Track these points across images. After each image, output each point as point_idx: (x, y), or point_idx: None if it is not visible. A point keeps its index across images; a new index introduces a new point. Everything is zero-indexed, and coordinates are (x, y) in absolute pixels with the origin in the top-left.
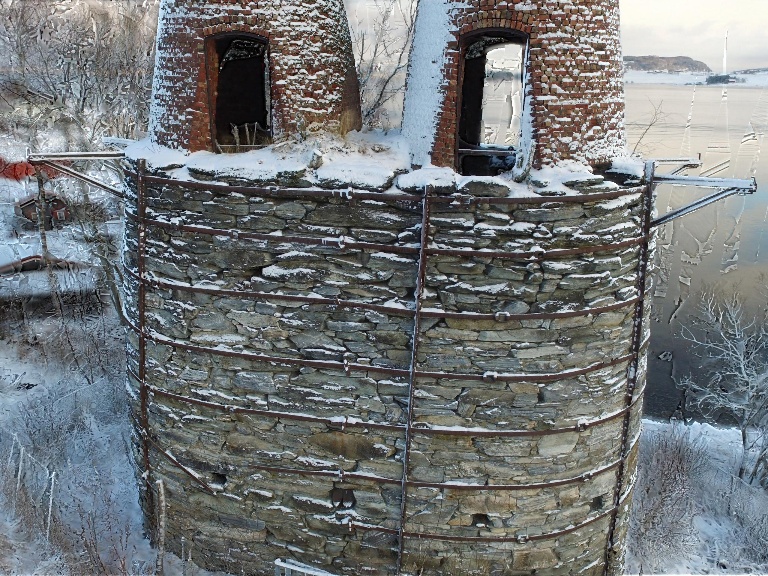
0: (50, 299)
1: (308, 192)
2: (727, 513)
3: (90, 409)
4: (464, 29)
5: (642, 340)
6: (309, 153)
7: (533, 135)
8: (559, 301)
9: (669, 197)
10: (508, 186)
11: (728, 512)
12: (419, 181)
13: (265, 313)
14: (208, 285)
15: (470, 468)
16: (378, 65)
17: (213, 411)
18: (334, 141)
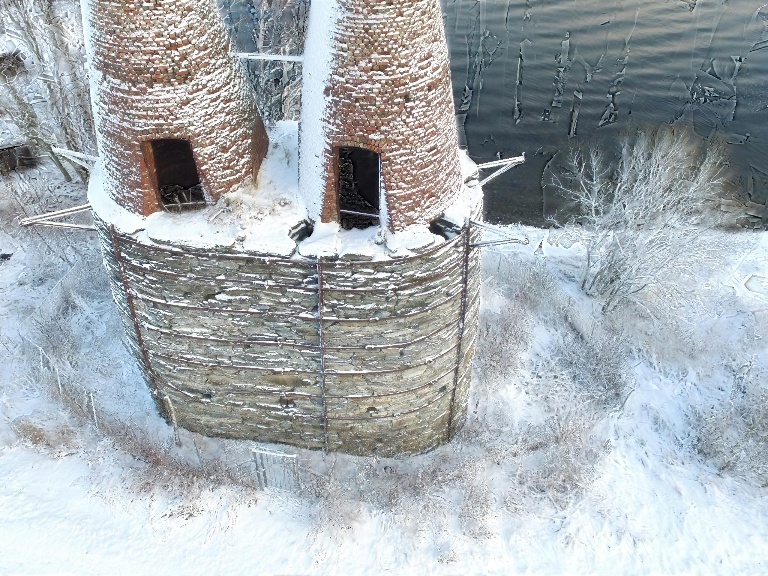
0: (12, 205)
1: (239, 257)
2: (566, 318)
3: (76, 290)
4: (335, 144)
5: (471, 298)
6: (236, 233)
7: (388, 213)
8: (409, 308)
9: None
10: (371, 255)
11: (566, 317)
12: (313, 252)
13: (221, 318)
14: (179, 303)
15: (363, 388)
16: None
17: (196, 365)
18: (251, 211)
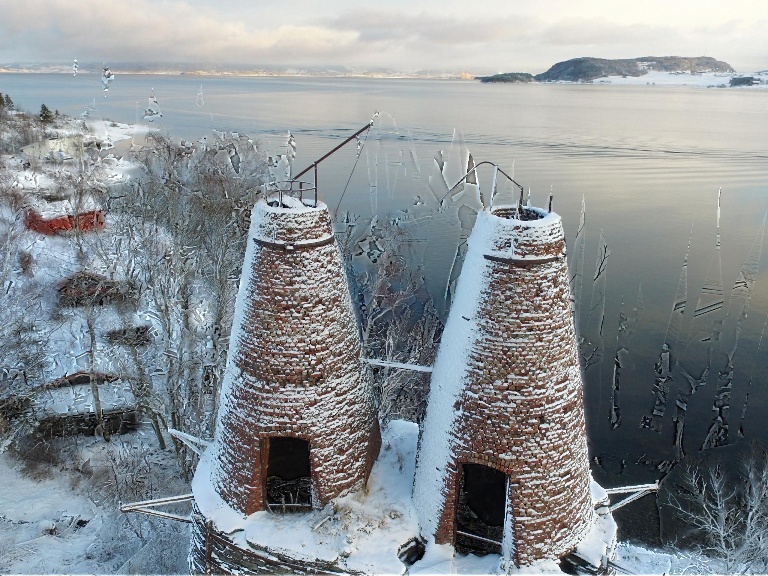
0: (107, 473)
1: None
2: None
3: (141, 573)
4: (461, 459)
5: None
6: (341, 547)
7: (513, 542)
8: None
9: (667, 325)
10: None
11: None
12: None
13: None
14: None
15: None
16: (396, 220)
17: None
18: (360, 522)
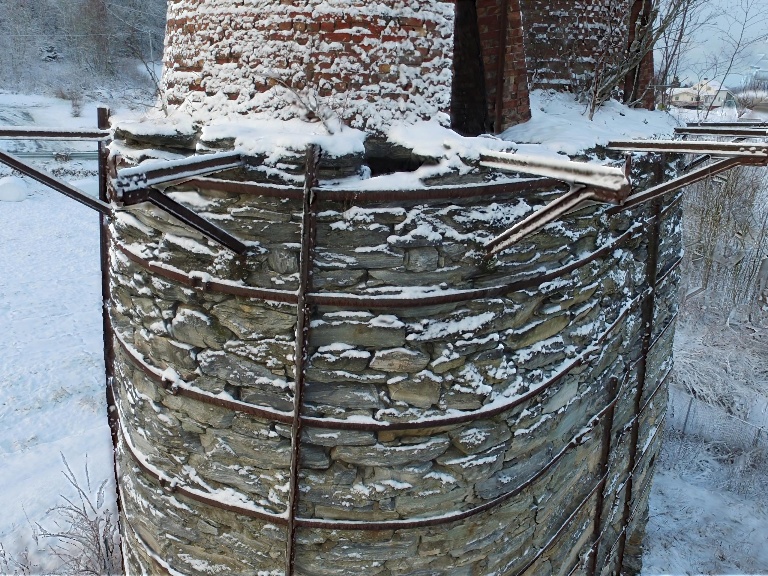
0: None
1: None
2: None
3: (761, 457)
4: None
5: None
6: None
7: None
8: None
9: None
10: None
11: None
12: None
13: None
14: None
15: None
16: None
17: None
18: None
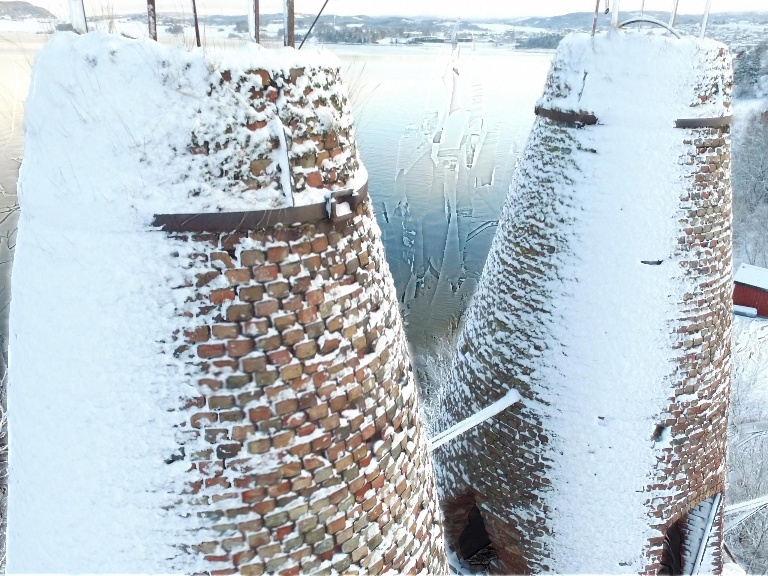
0: None
1: None
2: None
3: None
4: (673, 520)
5: None
6: None
7: None
8: None
9: None
10: None
11: None
12: None
13: None
14: None
15: None
16: None
17: None
18: None
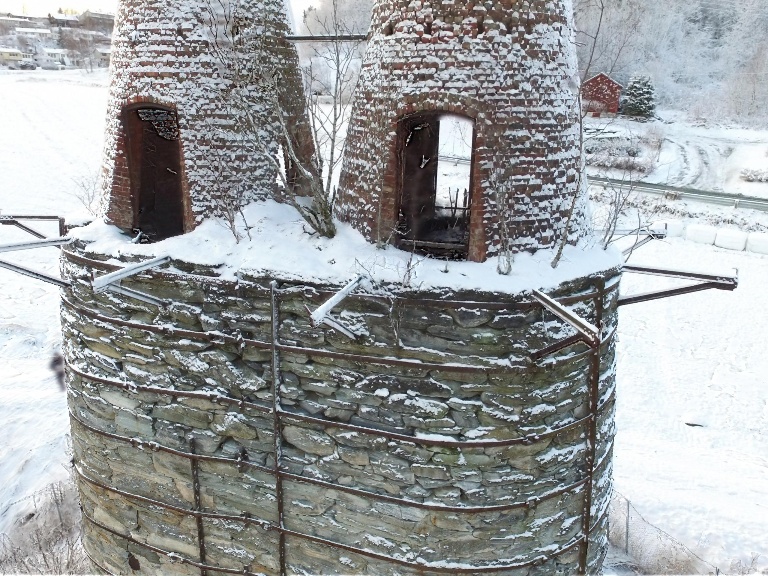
0: None
1: None
2: None
3: None
4: None
5: None
6: None
7: None
8: None
9: None
10: None
11: None
12: None
13: None
14: None
15: None
16: None
17: None
18: None
